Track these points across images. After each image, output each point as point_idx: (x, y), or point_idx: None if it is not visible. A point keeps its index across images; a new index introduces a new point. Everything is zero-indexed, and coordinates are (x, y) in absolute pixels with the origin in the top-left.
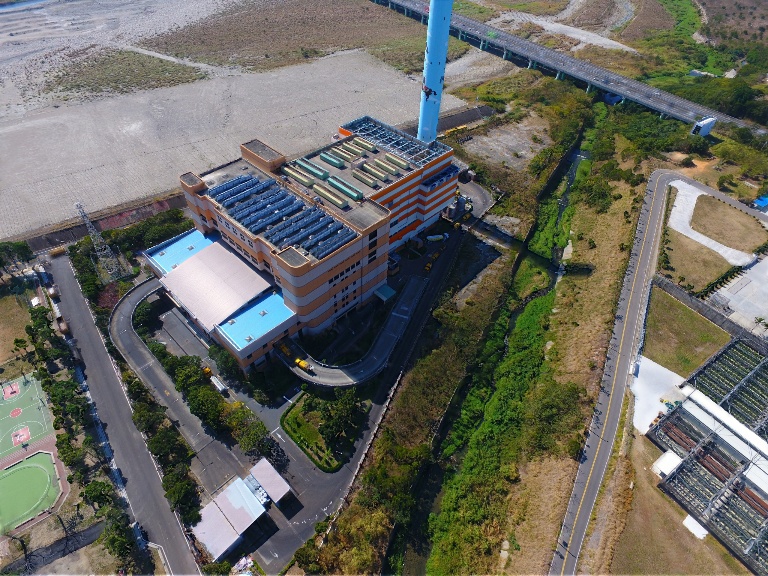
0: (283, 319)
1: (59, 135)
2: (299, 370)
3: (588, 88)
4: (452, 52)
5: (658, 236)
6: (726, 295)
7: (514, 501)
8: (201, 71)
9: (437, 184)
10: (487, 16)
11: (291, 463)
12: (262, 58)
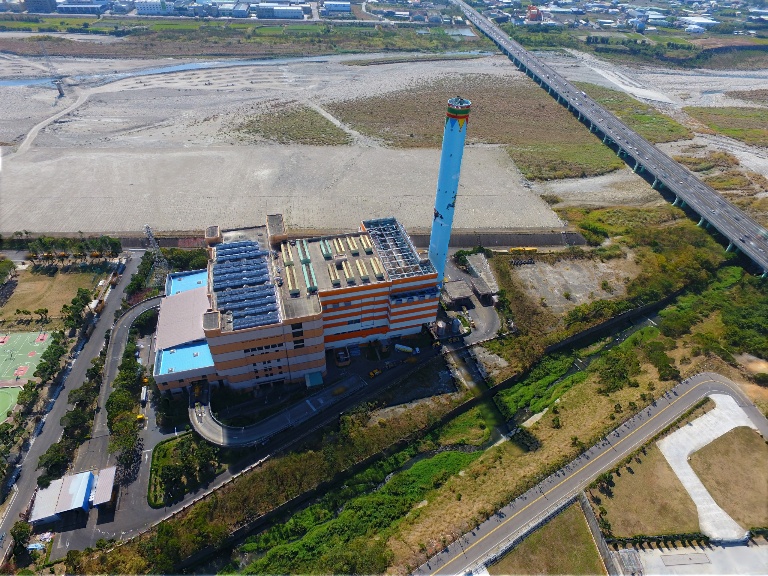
0: (204, 366)
1: (215, 166)
2: (194, 412)
3: (729, 246)
4: (596, 168)
5: (633, 449)
6: (653, 560)
7: None
8: (350, 137)
9: (406, 300)
10: (675, 136)
11: (135, 482)
12: (407, 136)
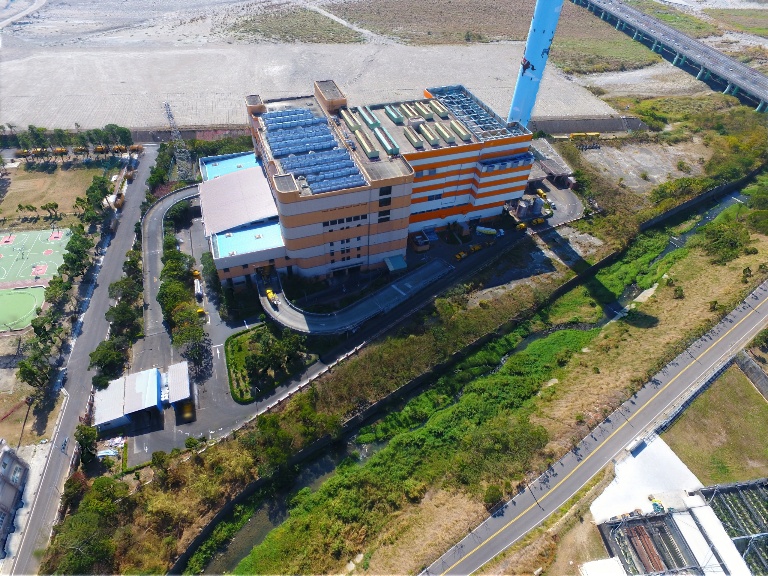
0: (271, 247)
1: (216, 63)
2: (266, 300)
3: None
4: (634, 61)
5: None
6: None
7: (398, 520)
8: (361, 36)
9: (497, 167)
10: (704, 33)
11: (212, 379)
12: (424, 34)
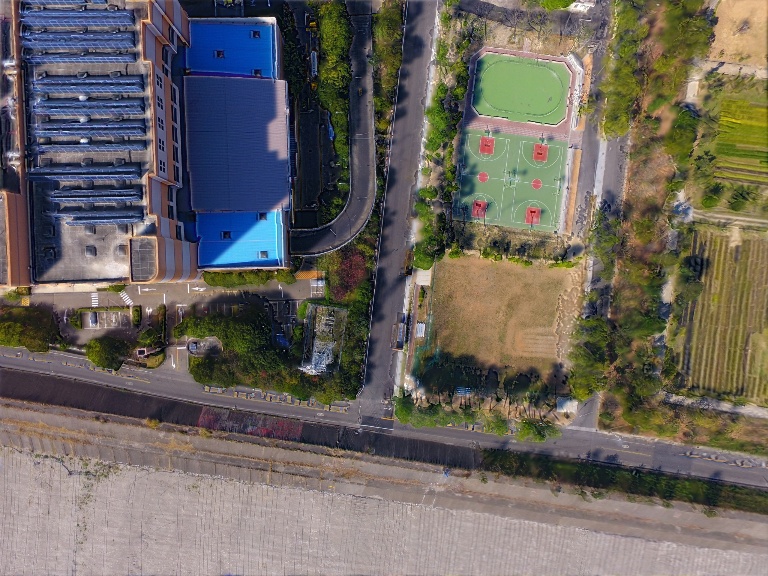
0: (206, 27)
1: None
2: None
3: None
4: None
5: None
6: None
7: None
8: None
9: None
10: None
11: None
12: None
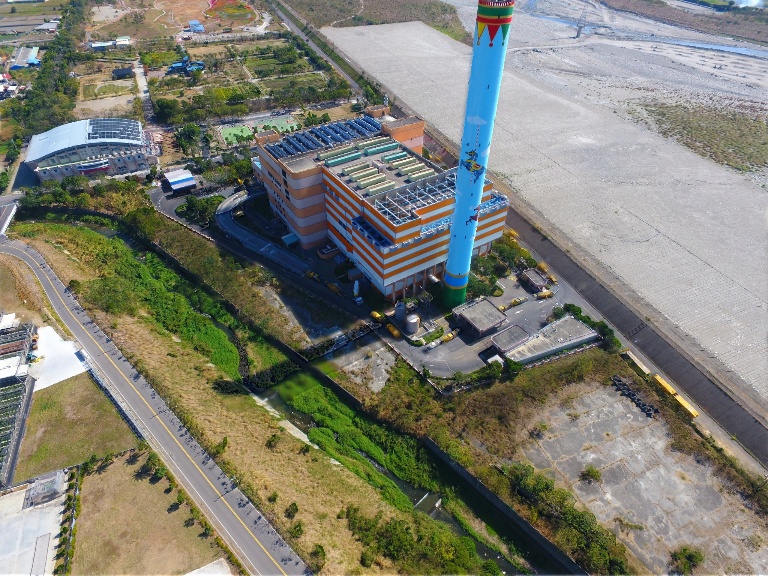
0: None
1: (559, 116)
2: None
3: None
4: None
5: None
6: (47, 522)
7: None
8: (761, 168)
9: None
10: None
11: None
12: None
